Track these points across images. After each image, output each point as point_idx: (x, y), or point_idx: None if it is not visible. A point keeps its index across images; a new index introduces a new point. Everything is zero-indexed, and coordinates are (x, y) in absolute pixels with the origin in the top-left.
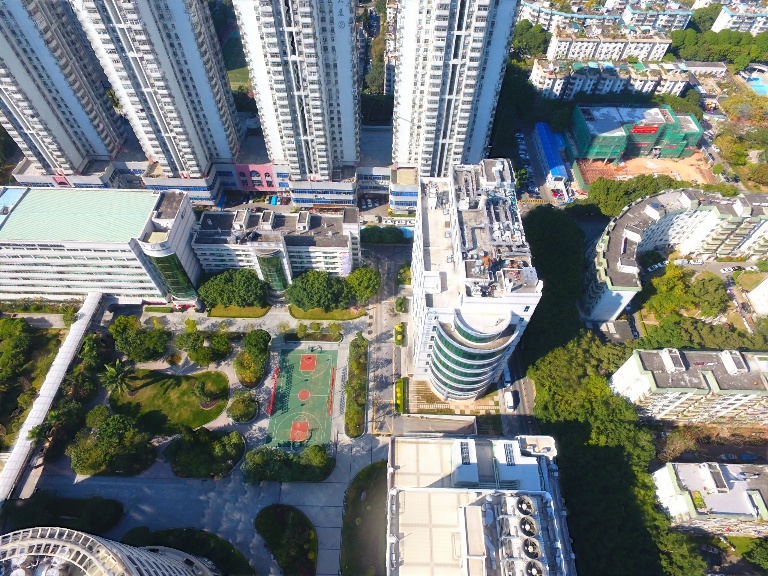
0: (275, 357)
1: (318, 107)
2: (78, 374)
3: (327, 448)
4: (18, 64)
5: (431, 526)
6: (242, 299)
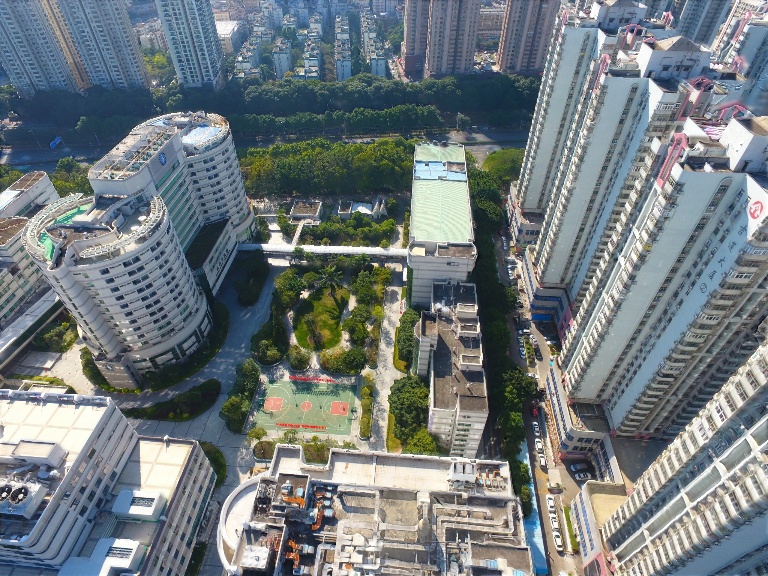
0: (349, 381)
1: (602, 325)
2: (340, 259)
3: (252, 426)
4: (557, 124)
5: (70, 428)
6: (399, 340)
